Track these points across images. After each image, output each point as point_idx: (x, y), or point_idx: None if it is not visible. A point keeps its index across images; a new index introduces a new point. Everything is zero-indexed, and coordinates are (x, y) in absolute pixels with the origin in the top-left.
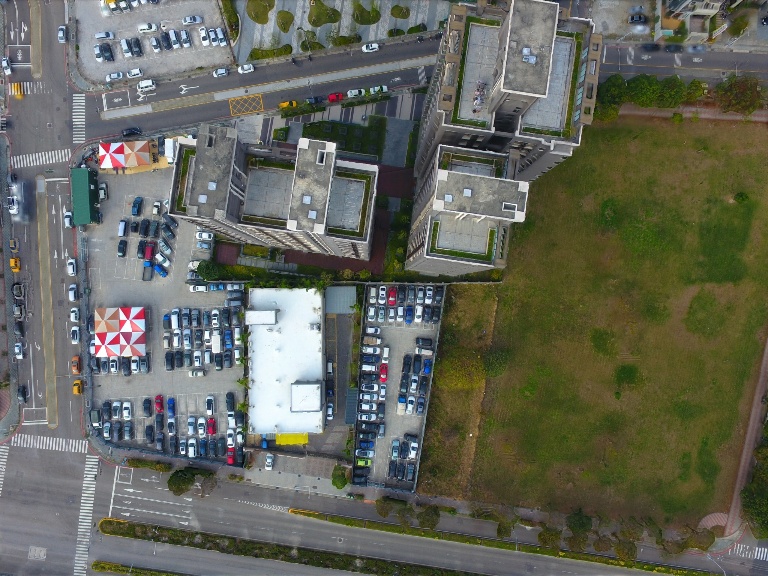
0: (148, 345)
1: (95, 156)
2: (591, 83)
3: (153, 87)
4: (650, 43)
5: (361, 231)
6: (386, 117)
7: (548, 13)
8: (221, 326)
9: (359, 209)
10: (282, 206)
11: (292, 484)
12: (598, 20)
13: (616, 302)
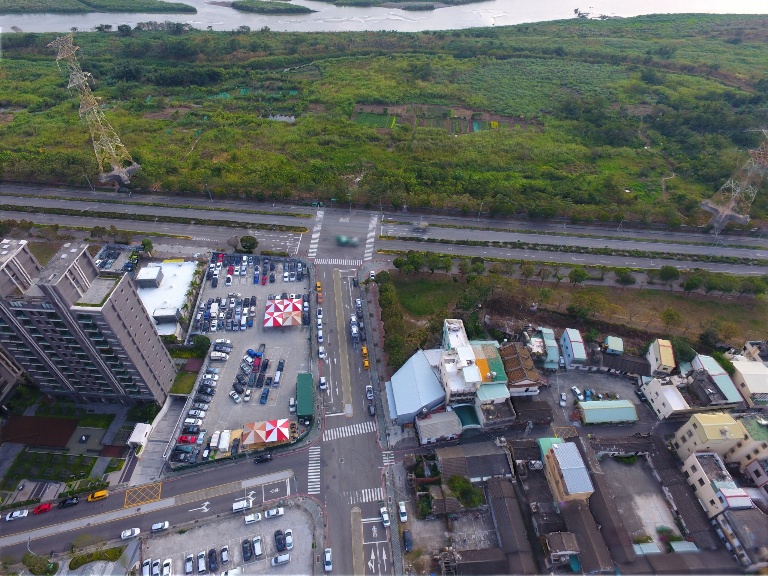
0: None
1: None
2: None
3: None
4: None
5: None
6: None
7: None
8: None
9: None
10: None
11: (186, 249)
12: None
13: None
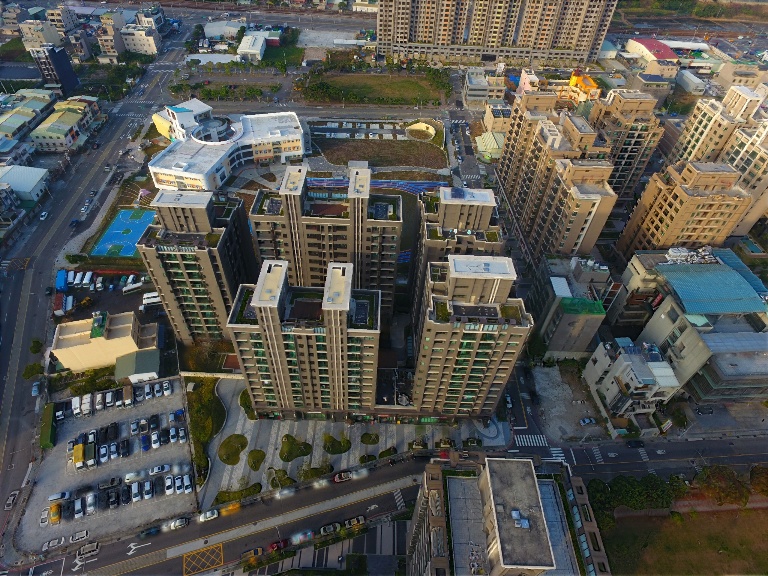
0: None
1: None
2: (592, 532)
3: (96, 551)
4: (610, 441)
5: None
6: (366, 555)
7: (524, 470)
8: None
9: None
10: None
11: None
12: (554, 426)
13: None
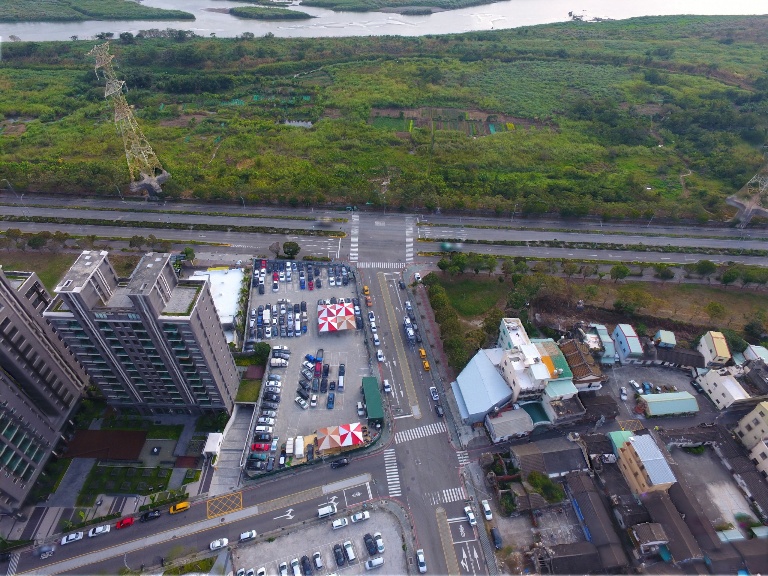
0: None
1: None
2: None
3: None
4: None
5: None
6: (75, 507)
7: None
8: None
9: None
10: None
11: (227, 256)
12: None
13: None
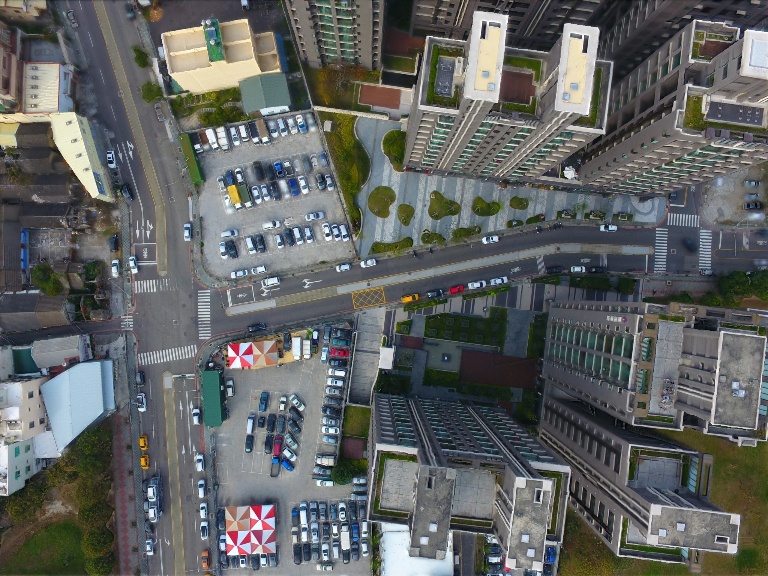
0: (276, 538)
1: (221, 352)
2: None
3: (278, 283)
4: (765, 229)
5: (553, 528)
6: (507, 308)
7: (756, 346)
8: (347, 518)
9: (550, 505)
10: (475, 504)
11: None
12: (713, 207)
13: (736, 487)
